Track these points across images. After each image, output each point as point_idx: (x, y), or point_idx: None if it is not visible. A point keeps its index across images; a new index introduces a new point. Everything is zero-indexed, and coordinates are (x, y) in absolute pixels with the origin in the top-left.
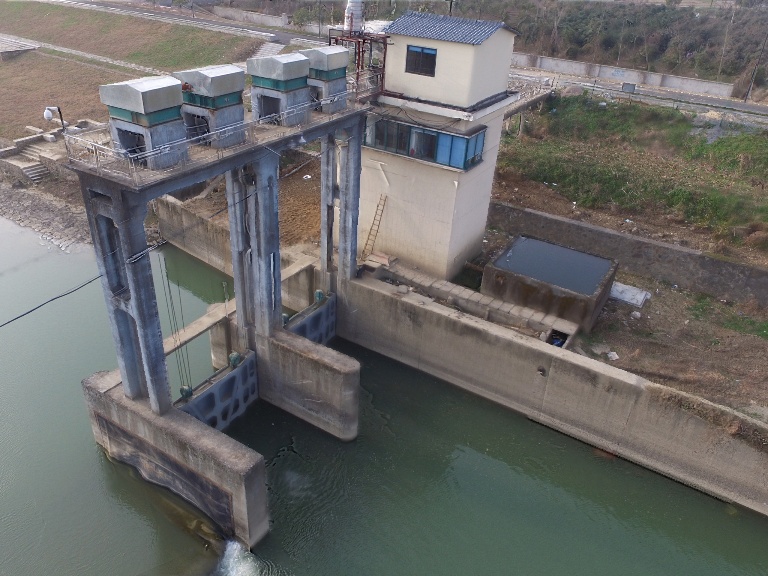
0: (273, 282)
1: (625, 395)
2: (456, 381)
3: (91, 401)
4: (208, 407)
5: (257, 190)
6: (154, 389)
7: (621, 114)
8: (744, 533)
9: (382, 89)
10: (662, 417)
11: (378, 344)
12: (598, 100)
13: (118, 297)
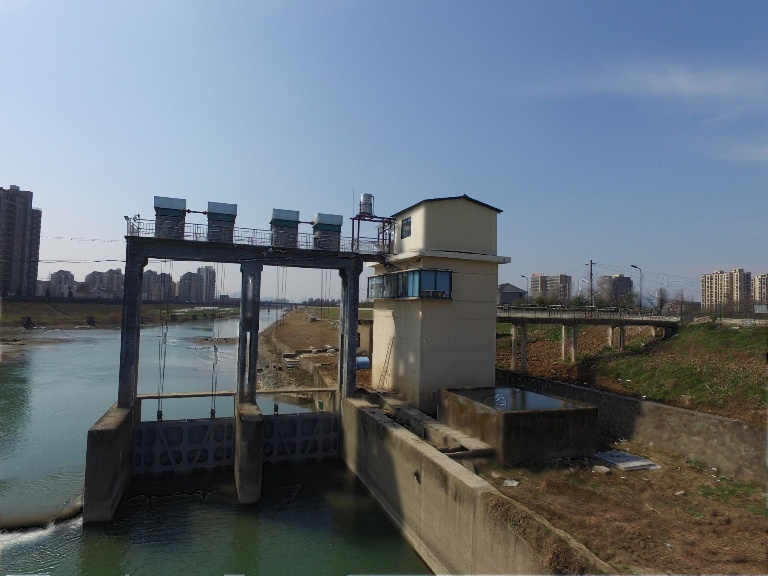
0: (248, 356)
1: (466, 505)
2: (381, 499)
3: None
4: None
5: (208, 260)
6: None
7: (754, 334)
8: None
9: None
10: (494, 541)
11: (352, 461)
12: (731, 326)
13: None
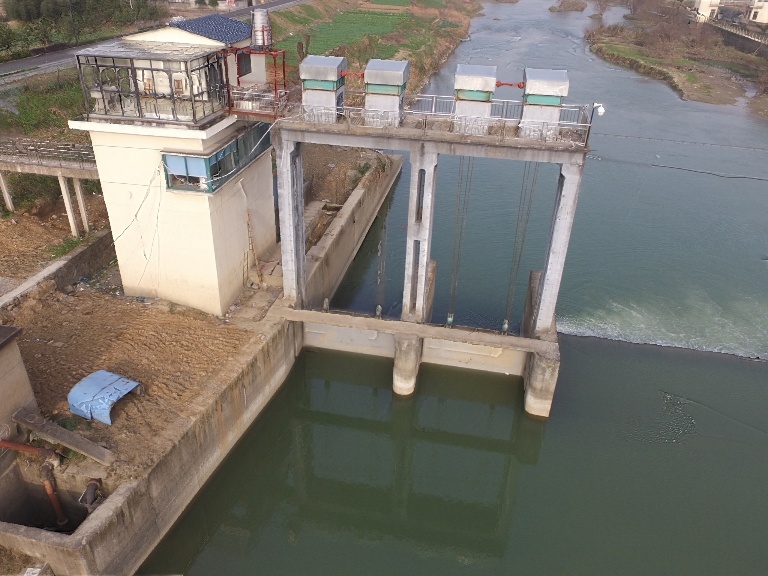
0: None
1: None
2: None
3: None
4: None
5: None
6: None
7: None
8: None
9: None
10: None
11: None
12: None
13: None
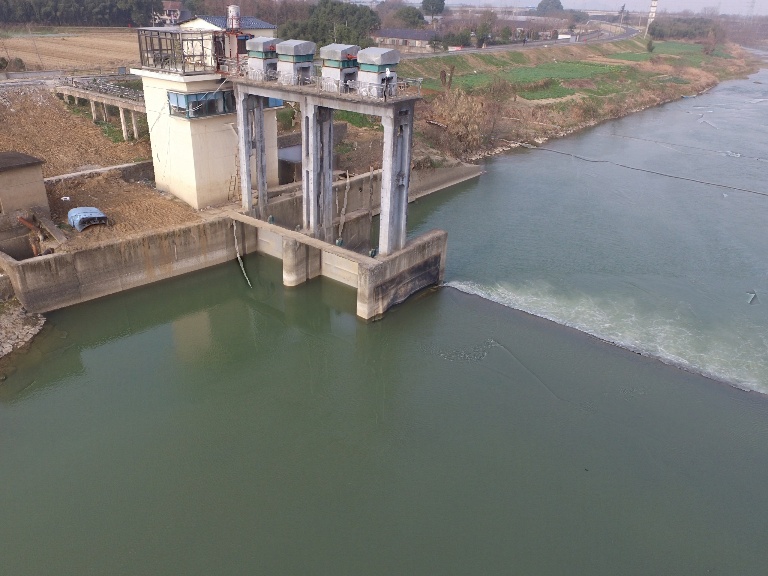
0: None
1: None
2: None
3: None
4: None
5: None
6: None
7: None
8: None
9: None
10: None
11: None
12: None
13: (398, 178)
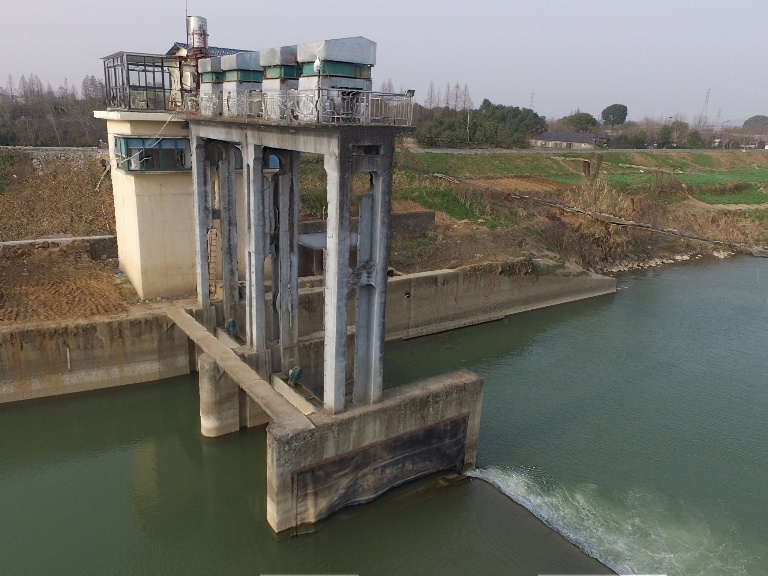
0: None
1: (452, 282)
2: None
3: (290, 460)
4: None
5: None
6: None
7: None
8: (517, 328)
9: None
10: (470, 284)
11: None
12: None
13: (357, 271)
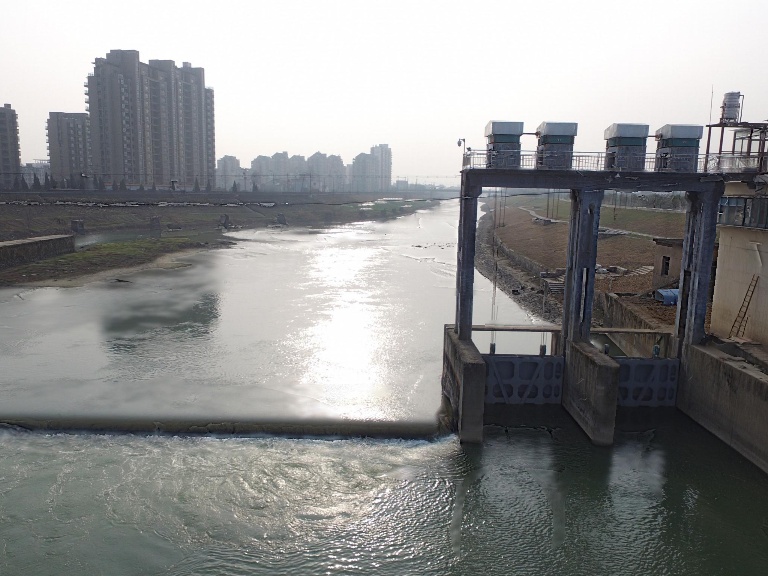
0: (584, 294)
1: None
2: (759, 462)
3: None
4: (509, 376)
5: None
6: (460, 317)
7: None
8: None
9: (760, 171)
10: None
11: (703, 415)
12: None
13: None
